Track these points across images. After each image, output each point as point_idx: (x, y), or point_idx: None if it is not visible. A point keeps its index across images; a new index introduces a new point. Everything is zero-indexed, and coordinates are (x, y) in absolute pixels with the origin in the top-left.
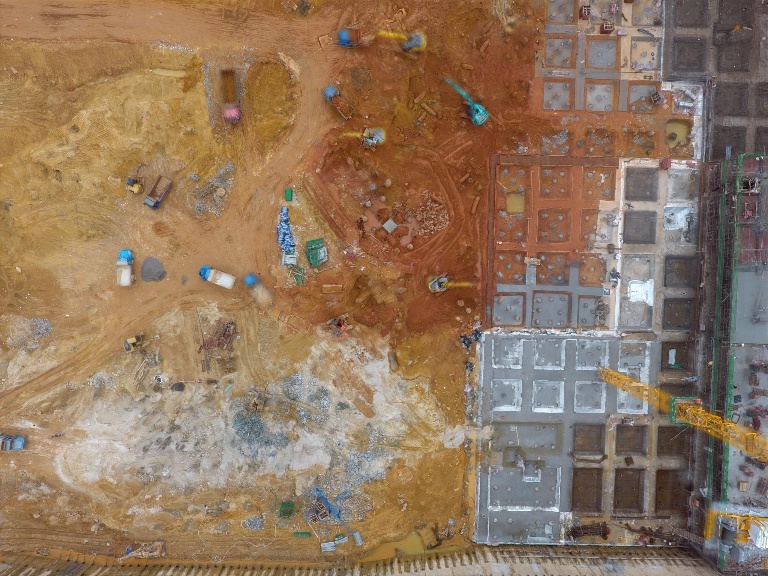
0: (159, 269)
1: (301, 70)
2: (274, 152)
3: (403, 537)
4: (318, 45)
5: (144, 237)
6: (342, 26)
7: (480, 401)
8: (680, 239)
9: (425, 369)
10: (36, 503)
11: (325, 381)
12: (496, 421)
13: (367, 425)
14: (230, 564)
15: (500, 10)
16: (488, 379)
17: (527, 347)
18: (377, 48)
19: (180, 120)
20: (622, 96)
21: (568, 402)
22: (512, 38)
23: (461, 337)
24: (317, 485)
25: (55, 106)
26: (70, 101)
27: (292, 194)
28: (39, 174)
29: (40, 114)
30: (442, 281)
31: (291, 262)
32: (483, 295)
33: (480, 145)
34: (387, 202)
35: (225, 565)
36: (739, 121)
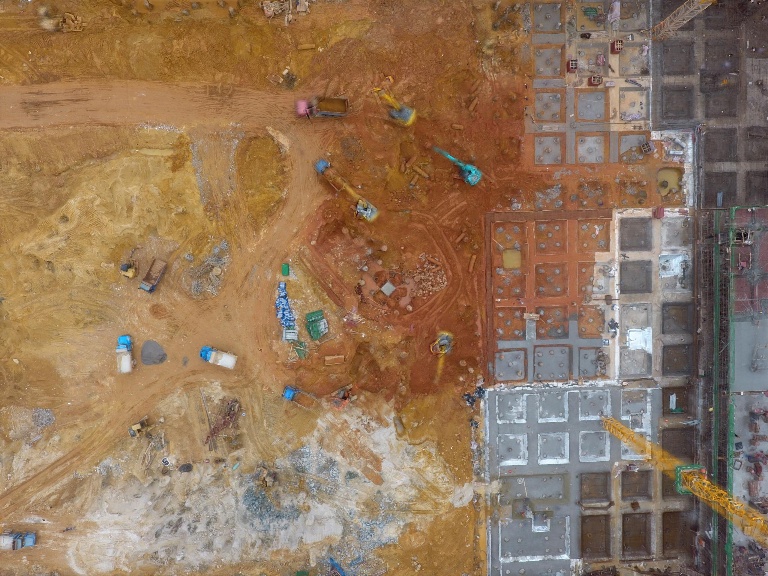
0: (159, 352)
1: (290, 143)
2: (268, 227)
3: None
4: (306, 117)
5: (142, 320)
6: (329, 97)
7: (487, 457)
8: (676, 286)
9: (431, 430)
10: None
11: (333, 452)
12: (503, 475)
13: (377, 493)
14: None
15: (487, 68)
16: (494, 435)
17: (530, 401)
18: (366, 117)
19: (171, 201)
20: (613, 148)
21: (573, 452)
22: (500, 96)
23: (465, 395)
24: (331, 553)
25: (41, 192)
26: (56, 186)
27: (289, 268)
28: (30, 265)
29: (26, 201)
30: (443, 344)
31: (292, 337)
32: (484, 352)
33: (474, 205)
34: (384, 265)
35: None
36: (729, 166)
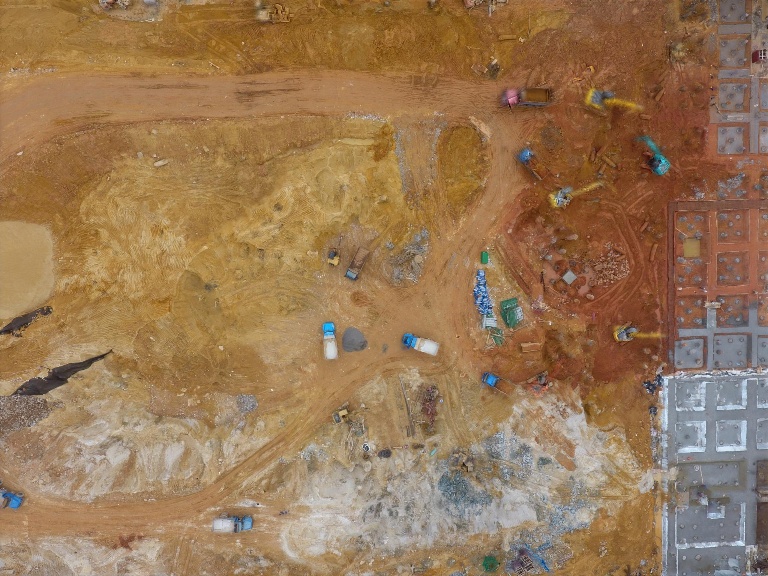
0: (361, 339)
1: (492, 133)
2: (467, 216)
3: None
4: (508, 107)
5: (343, 308)
6: (531, 86)
7: (665, 444)
8: None
9: (615, 418)
10: None
11: (528, 438)
12: (682, 462)
13: (570, 478)
14: None
15: (674, 58)
16: (672, 422)
17: (710, 389)
18: (566, 107)
19: (374, 190)
20: None
21: (751, 440)
22: (688, 86)
23: (645, 383)
24: (520, 538)
25: (246, 182)
26: (261, 176)
27: None
28: (240, 253)
29: (231, 190)
30: (631, 332)
31: (491, 325)
32: (664, 340)
33: (660, 194)
34: (564, 254)
35: None
36: None
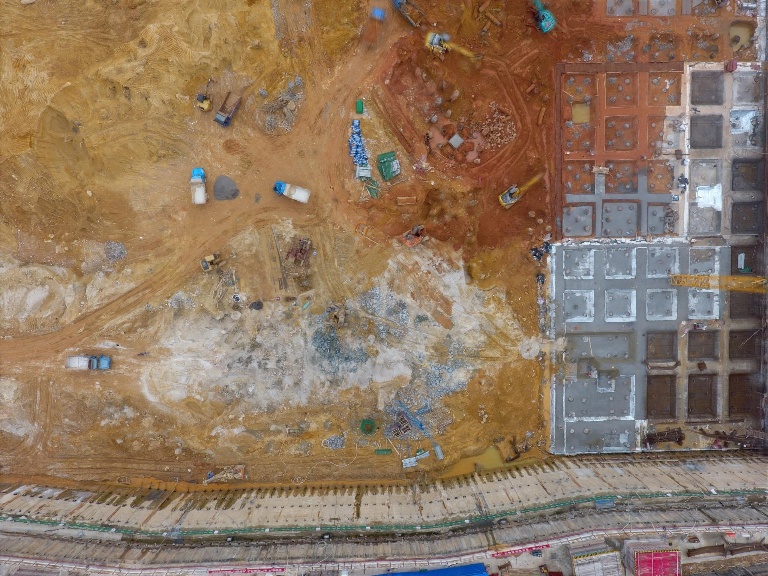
0: (232, 187)
1: None
2: (342, 64)
3: (482, 451)
4: None
5: (215, 155)
6: None
7: (553, 313)
8: (746, 143)
9: (499, 282)
10: (120, 427)
11: (403, 294)
12: (569, 332)
13: (447, 336)
14: (312, 485)
15: None
16: (560, 291)
17: (598, 257)
18: None
19: (247, 34)
20: None
21: (640, 310)
22: None
23: (532, 250)
24: (398, 400)
25: (117, 25)
26: (132, 19)
27: (362, 106)
28: (107, 93)
29: (102, 34)
30: (514, 191)
31: (365, 174)
32: (552, 207)
33: (546, 53)
34: (452, 118)
35: (307, 486)
36: None
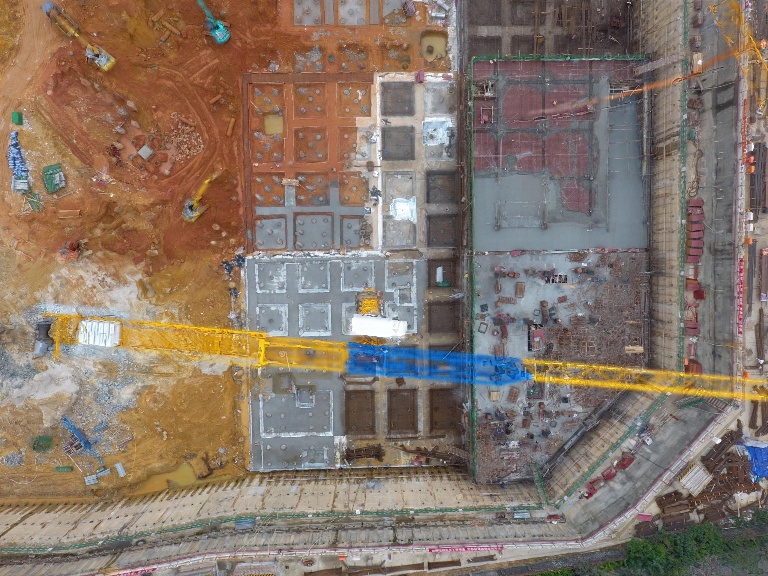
0: None
1: None
2: (0, 74)
3: (172, 468)
4: None
5: None
6: None
7: (247, 328)
8: (442, 154)
9: (183, 296)
10: None
11: (68, 309)
12: None
13: (114, 352)
14: None
15: None
16: (253, 305)
17: (290, 270)
18: None
19: None
20: (373, 9)
21: (335, 325)
22: None
23: (223, 263)
24: (71, 417)
25: None
26: None
27: (22, 117)
28: None
29: None
30: (191, 204)
31: (22, 187)
32: (244, 219)
33: (227, 63)
34: (142, 128)
35: None
36: (493, 31)
